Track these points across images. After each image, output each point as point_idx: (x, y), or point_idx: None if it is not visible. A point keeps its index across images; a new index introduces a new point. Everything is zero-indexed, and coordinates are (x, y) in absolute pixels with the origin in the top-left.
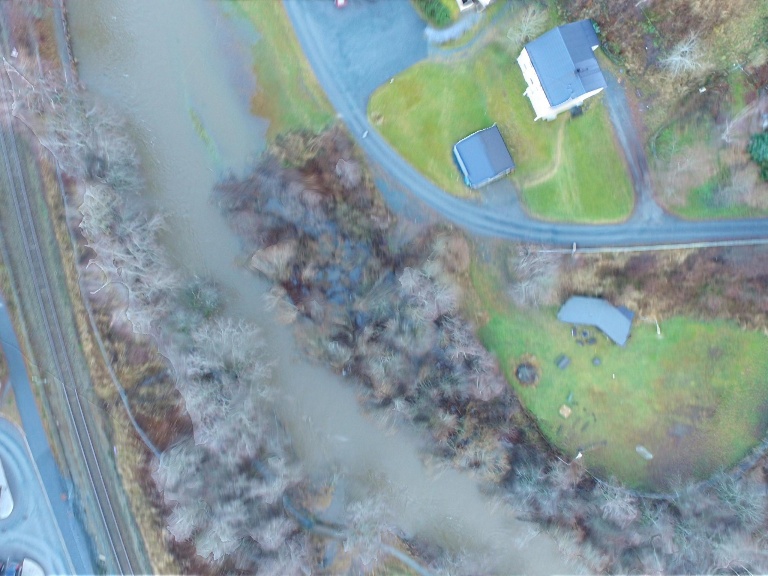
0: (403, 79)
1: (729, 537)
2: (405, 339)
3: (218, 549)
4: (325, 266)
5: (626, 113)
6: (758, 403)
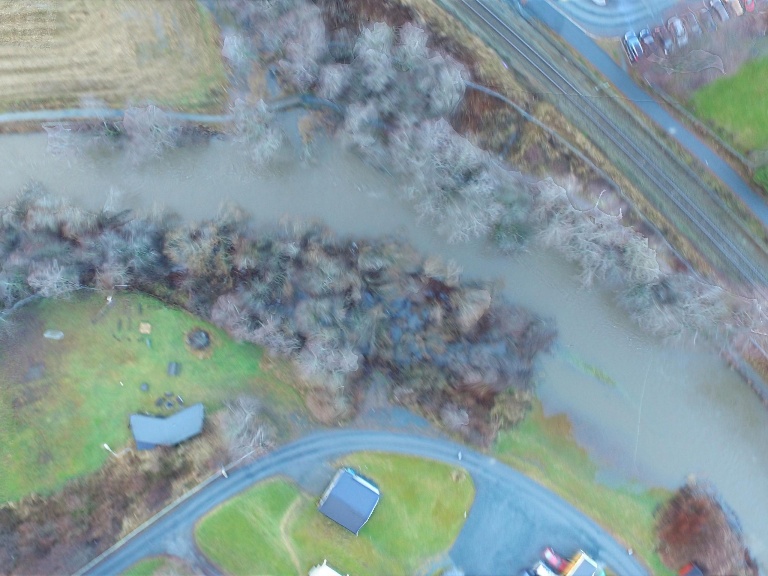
0: (458, 522)
1: None
2: (322, 309)
3: (371, 39)
4: (426, 325)
5: None
6: None
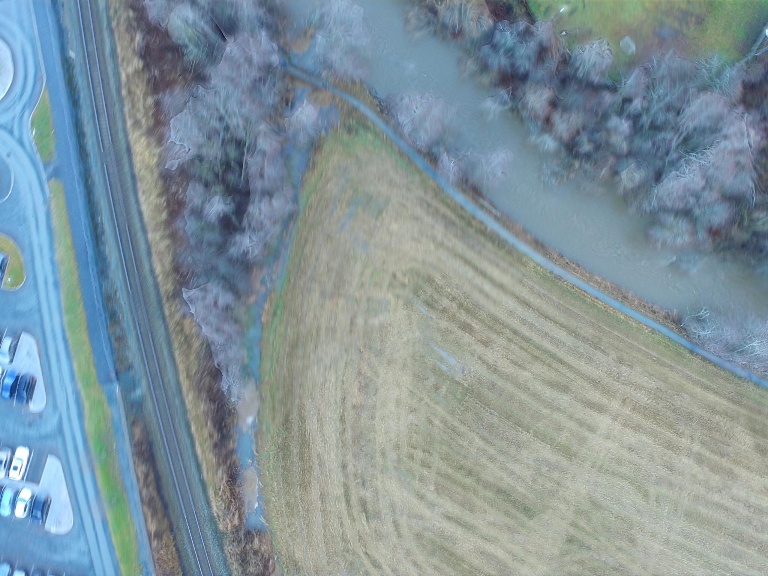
0: None
1: (700, 98)
2: None
3: (191, 11)
4: None
5: None
6: (748, 19)
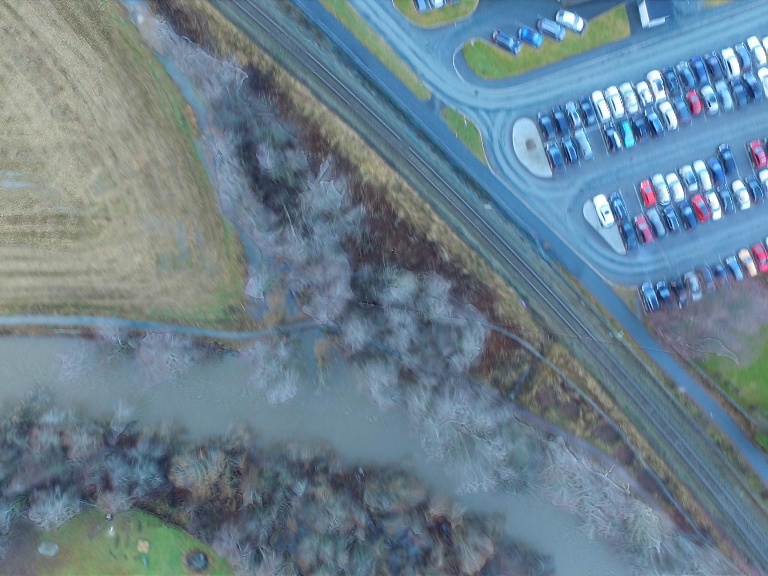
0: None
1: None
2: (326, 554)
3: (396, 296)
4: (426, 557)
5: None
6: None
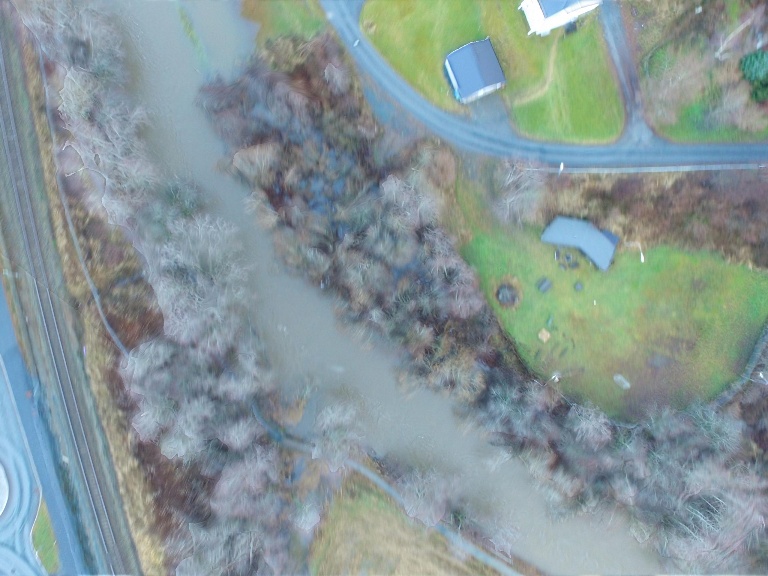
0: None
1: (702, 463)
2: (385, 246)
3: (183, 446)
4: (309, 175)
5: (621, 31)
6: (739, 338)
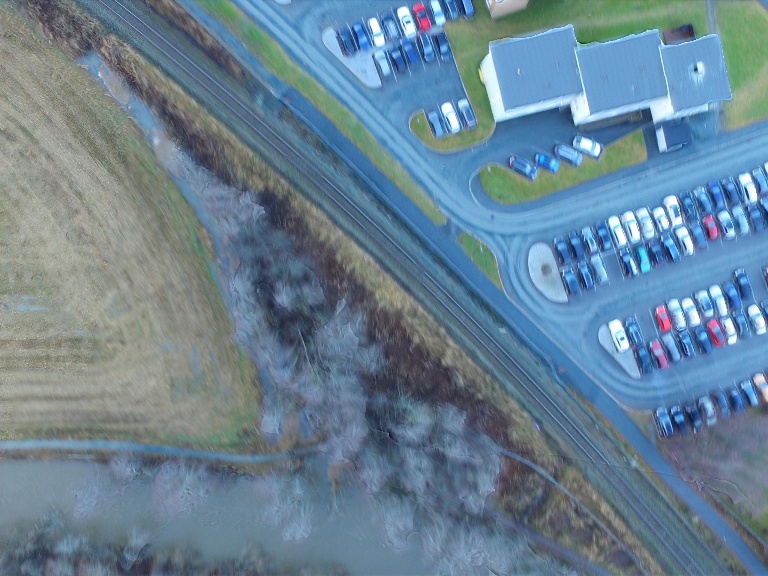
0: None
1: None
2: None
3: (412, 436)
4: None
5: None
6: None
